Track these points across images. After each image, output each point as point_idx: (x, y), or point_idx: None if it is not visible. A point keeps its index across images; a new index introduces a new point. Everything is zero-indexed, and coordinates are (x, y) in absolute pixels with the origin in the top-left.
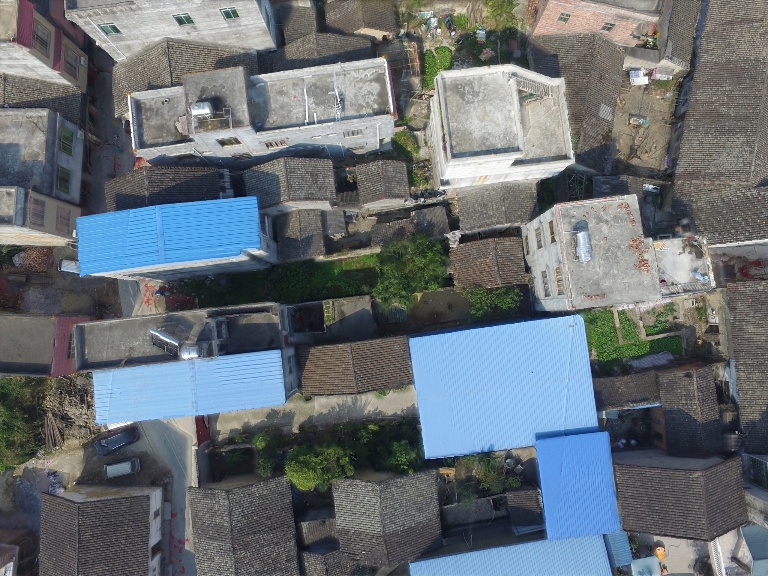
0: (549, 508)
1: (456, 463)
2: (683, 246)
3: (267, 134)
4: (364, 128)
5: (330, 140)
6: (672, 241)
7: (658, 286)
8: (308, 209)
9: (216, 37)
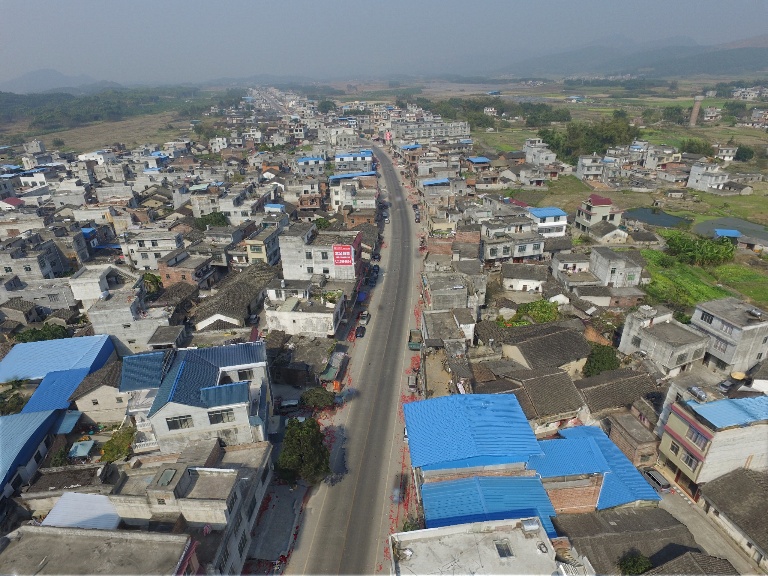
0: (33, 399)
1: (2, 405)
2: (164, 309)
3: (12, 292)
4: (57, 293)
5: (44, 303)
6: (160, 308)
7: (130, 305)
8: (14, 321)
9: (21, 280)
